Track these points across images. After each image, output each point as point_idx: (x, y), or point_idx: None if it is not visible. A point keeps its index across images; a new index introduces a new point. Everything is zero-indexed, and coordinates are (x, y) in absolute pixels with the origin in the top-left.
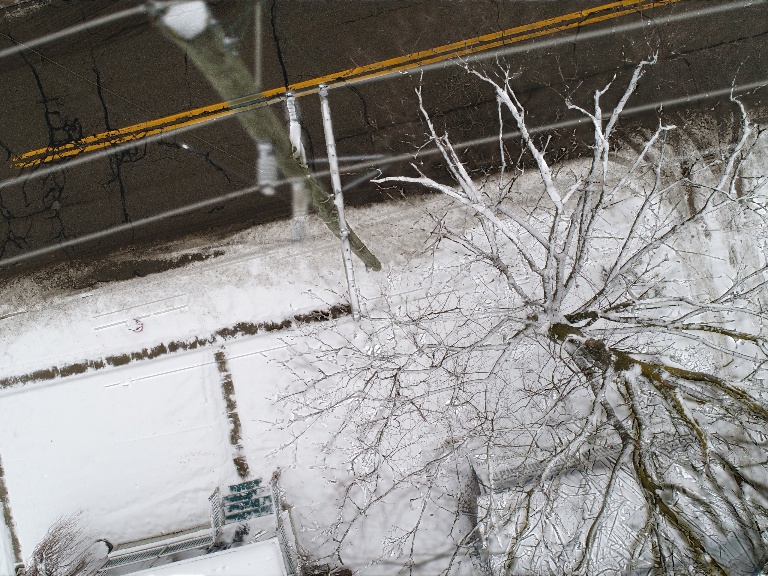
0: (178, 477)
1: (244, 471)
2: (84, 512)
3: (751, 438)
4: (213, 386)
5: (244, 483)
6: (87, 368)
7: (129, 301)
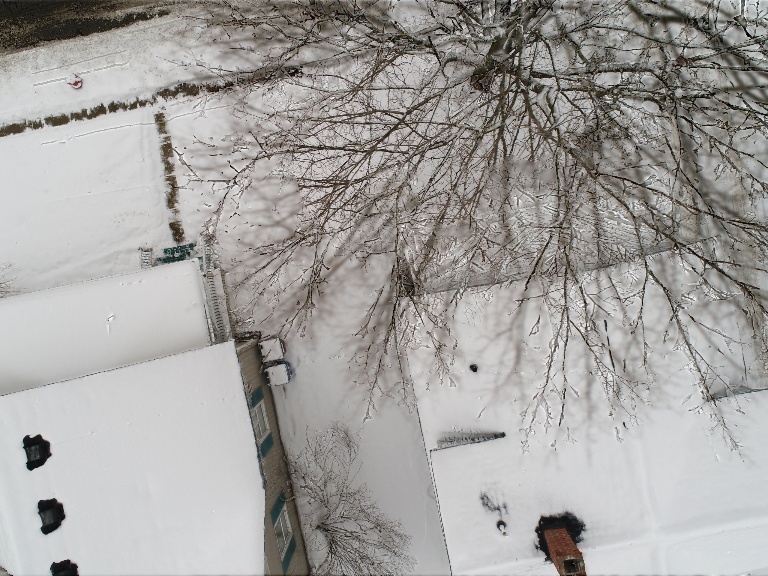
0: (111, 237)
1: (179, 236)
2: (13, 266)
3: None
4: (151, 147)
5: (178, 246)
6: (25, 128)
7: (70, 58)
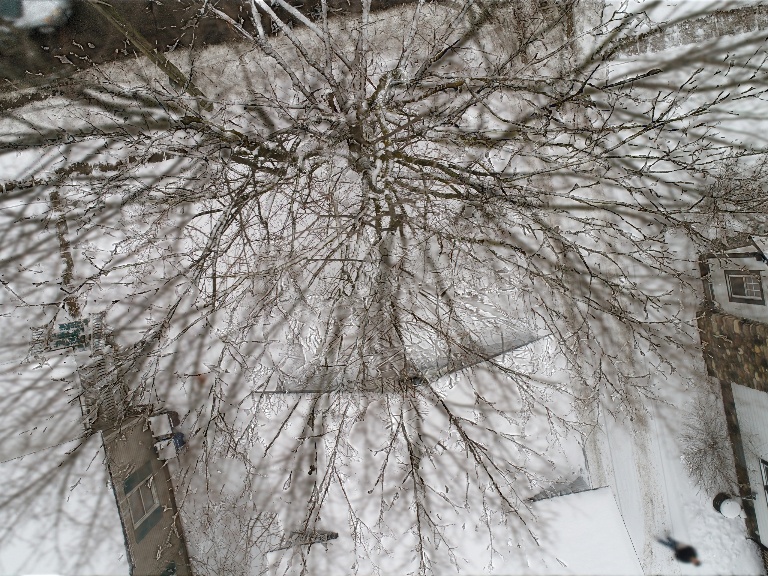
0: None
1: None
2: None
3: (494, 213)
4: None
5: (73, 322)
6: None
7: None
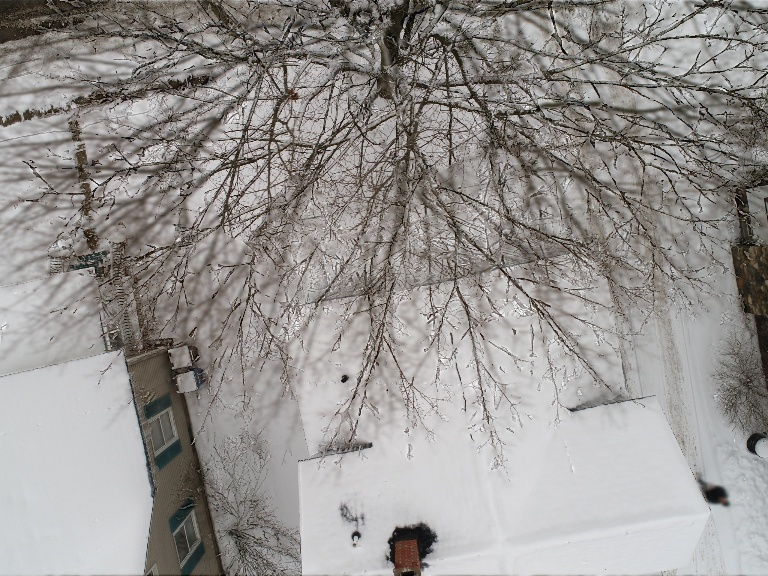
0: (25, 244)
1: (94, 243)
2: None
3: None
4: (66, 155)
5: (92, 254)
6: None
7: None
